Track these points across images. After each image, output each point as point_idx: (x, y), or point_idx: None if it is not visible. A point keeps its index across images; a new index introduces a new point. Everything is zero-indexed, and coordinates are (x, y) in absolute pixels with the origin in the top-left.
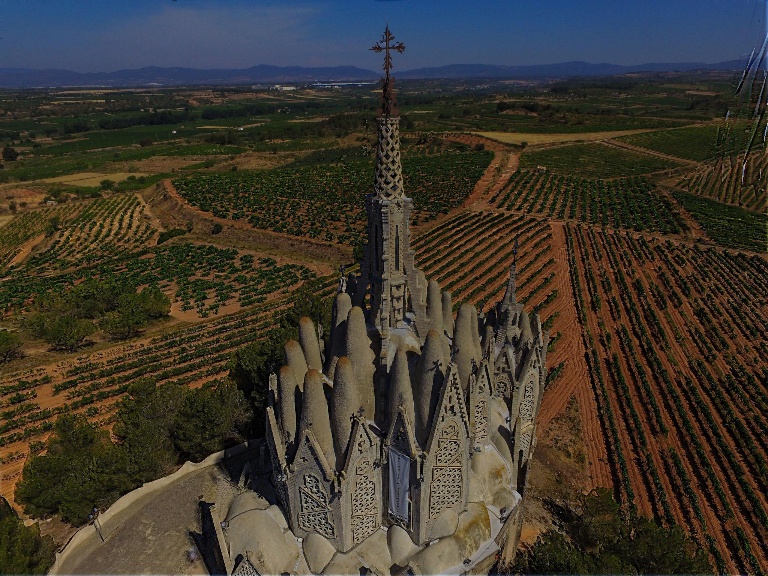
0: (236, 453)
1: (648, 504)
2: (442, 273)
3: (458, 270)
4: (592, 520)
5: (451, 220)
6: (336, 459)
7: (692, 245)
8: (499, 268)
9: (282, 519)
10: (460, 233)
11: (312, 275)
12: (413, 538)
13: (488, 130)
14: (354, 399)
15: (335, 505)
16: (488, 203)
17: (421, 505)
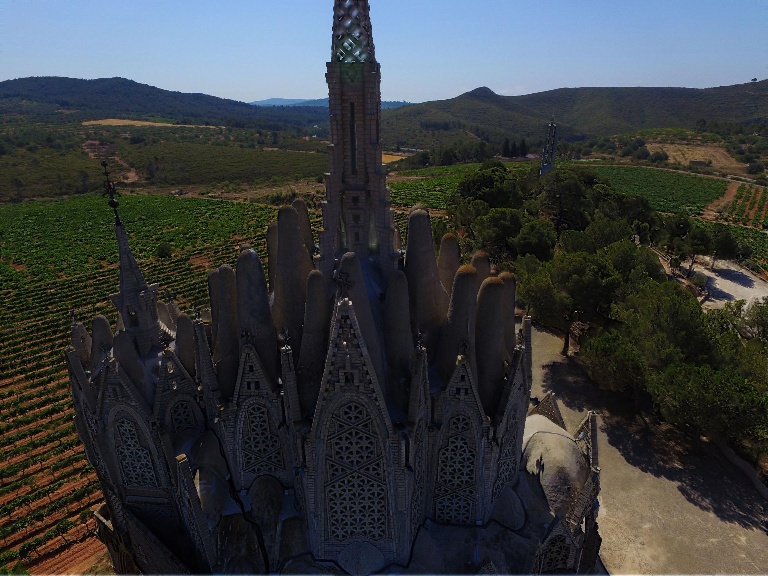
0: None
1: None
2: None
3: None
4: None
5: None
6: None
7: None
8: None
9: None
10: None
11: None
12: None
13: None
14: None
15: None
16: None
17: None
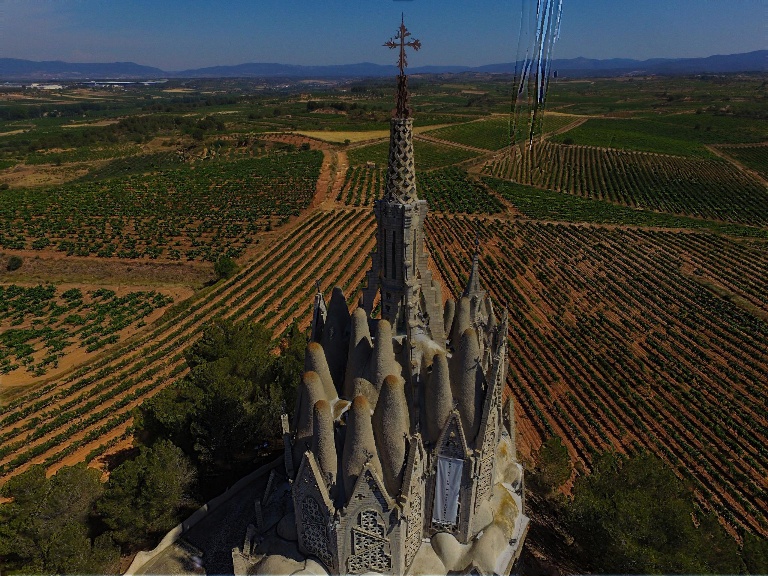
0: (195, 522)
1: (569, 442)
2: (317, 276)
3: (332, 270)
4: (545, 470)
5: (306, 221)
6: (385, 486)
7: (514, 221)
8: (370, 263)
9: (322, 572)
10: (320, 233)
11: (168, 300)
12: (460, 539)
13: (310, 129)
14: (404, 417)
15: (394, 534)
16: (335, 201)
17: (471, 503)
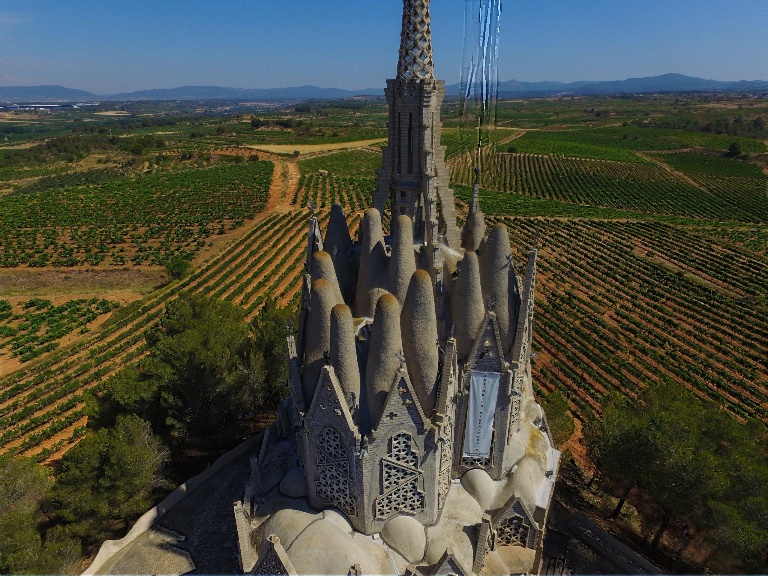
0: (172, 504)
1: None
2: (279, 272)
3: (295, 266)
4: None
5: (262, 223)
6: None
7: None
8: None
9: (344, 522)
10: (278, 233)
11: (114, 305)
12: (493, 475)
13: (258, 141)
14: None
15: (428, 463)
16: (290, 204)
17: (506, 428)
